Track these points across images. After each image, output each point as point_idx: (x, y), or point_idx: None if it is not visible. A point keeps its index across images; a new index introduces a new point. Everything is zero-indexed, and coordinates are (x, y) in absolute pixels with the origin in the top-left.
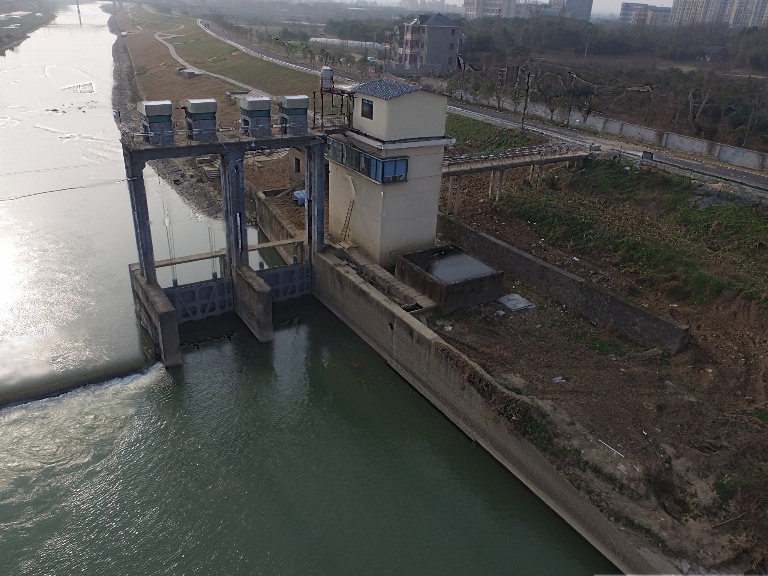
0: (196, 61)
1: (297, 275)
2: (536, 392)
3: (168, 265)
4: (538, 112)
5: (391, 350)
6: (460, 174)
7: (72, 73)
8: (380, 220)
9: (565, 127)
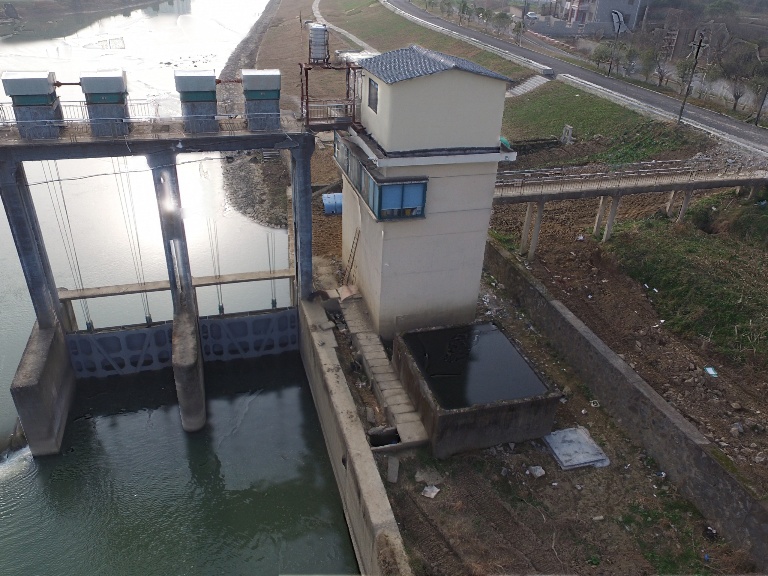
0: (331, 13)
1: (275, 325)
2: None
3: (94, 297)
4: (716, 96)
5: (345, 496)
6: (541, 200)
7: (206, 24)
8: (380, 272)
9: (752, 123)
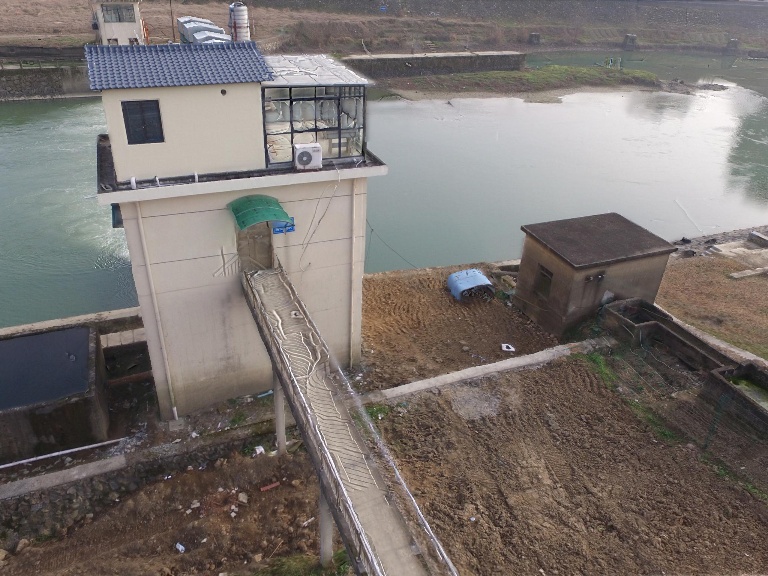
0: None
1: None
2: None
3: None
4: None
5: None
6: None
7: None
8: None
9: None
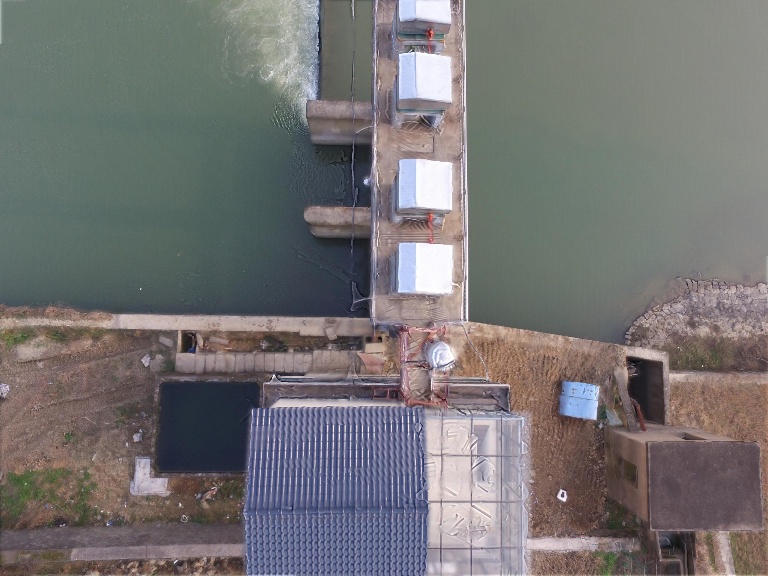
0: None
1: None
2: (6, 356)
3: None
4: None
5: None
6: None
7: None
8: None
9: None
